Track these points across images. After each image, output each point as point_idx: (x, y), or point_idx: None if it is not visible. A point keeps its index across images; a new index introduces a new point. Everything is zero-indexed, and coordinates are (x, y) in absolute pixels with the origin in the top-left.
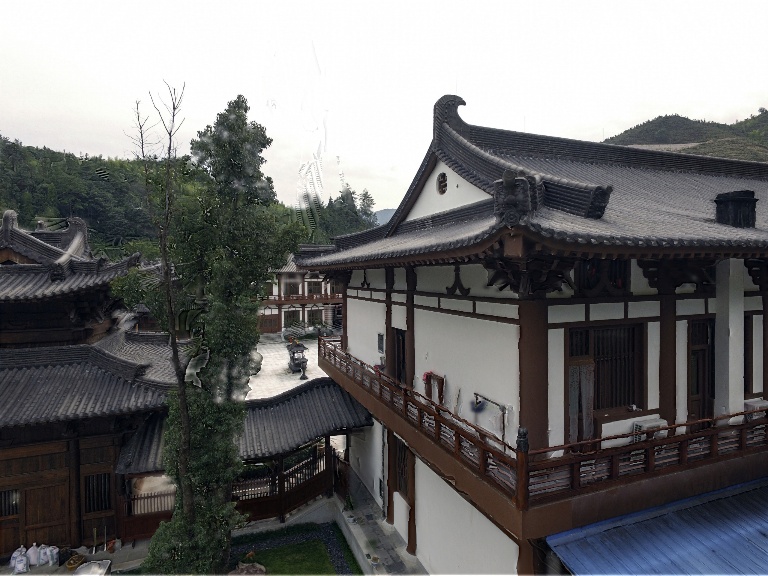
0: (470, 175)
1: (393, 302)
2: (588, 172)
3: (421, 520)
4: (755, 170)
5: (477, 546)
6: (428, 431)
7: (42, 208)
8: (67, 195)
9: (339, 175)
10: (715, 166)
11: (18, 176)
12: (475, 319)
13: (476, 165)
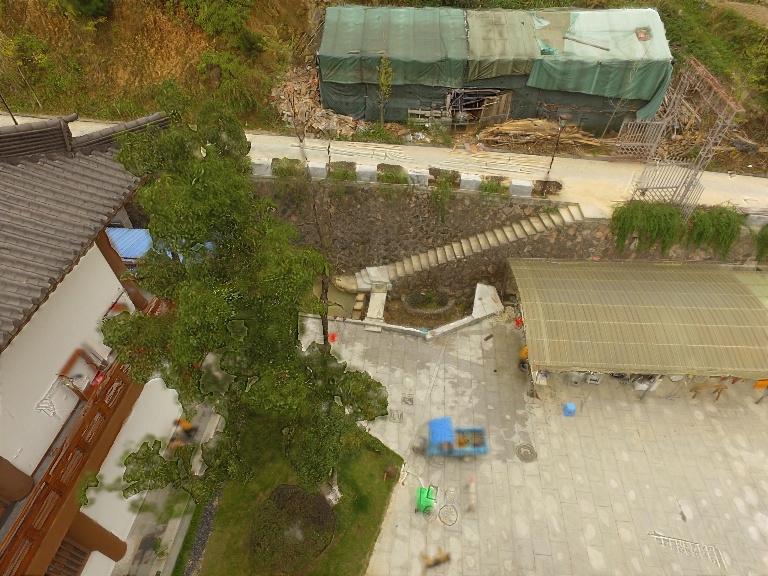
0: None
1: None
2: None
3: (112, 512)
4: None
5: None
6: None
7: None
8: None
9: None
10: None
11: None
12: None
13: None
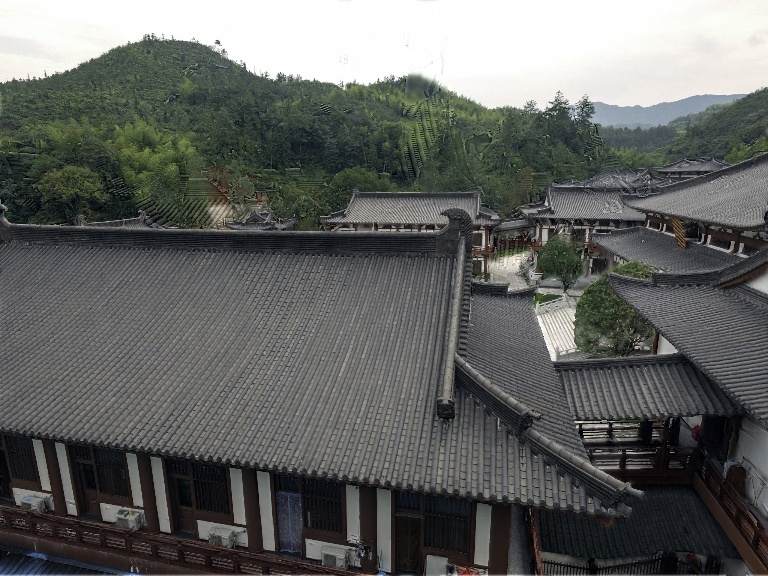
0: None
1: None
2: (74, 264)
3: None
4: (320, 243)
5: None
6: None
7: (192, 172)
8: (297, 131)
9: (451, 112)
10: (256, 242)
11: (267, 118)
12: None
13: None
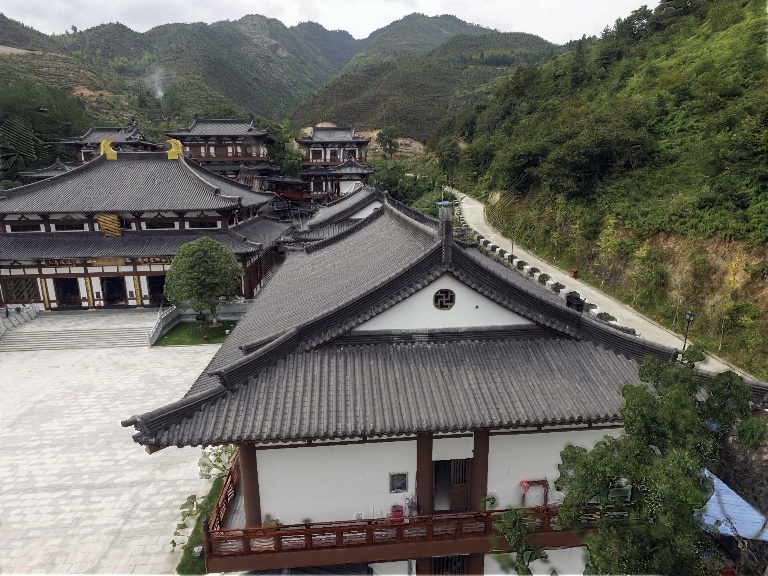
0: (511, 305)
1: (437, 436)
2: None
3: None
4: None
5: (582, 567)
6: (591, 525)
7: None
8: None
9: None
10: None
11: None
12: (593, 431)
13: (514, 295)
